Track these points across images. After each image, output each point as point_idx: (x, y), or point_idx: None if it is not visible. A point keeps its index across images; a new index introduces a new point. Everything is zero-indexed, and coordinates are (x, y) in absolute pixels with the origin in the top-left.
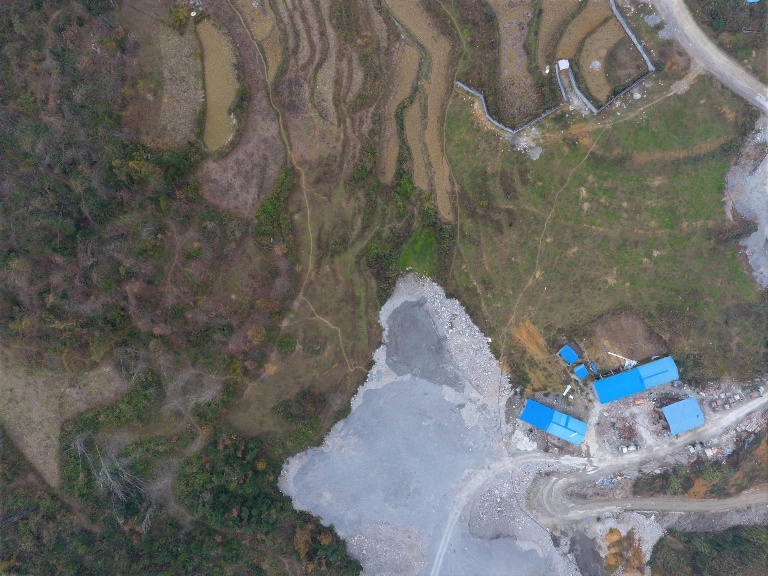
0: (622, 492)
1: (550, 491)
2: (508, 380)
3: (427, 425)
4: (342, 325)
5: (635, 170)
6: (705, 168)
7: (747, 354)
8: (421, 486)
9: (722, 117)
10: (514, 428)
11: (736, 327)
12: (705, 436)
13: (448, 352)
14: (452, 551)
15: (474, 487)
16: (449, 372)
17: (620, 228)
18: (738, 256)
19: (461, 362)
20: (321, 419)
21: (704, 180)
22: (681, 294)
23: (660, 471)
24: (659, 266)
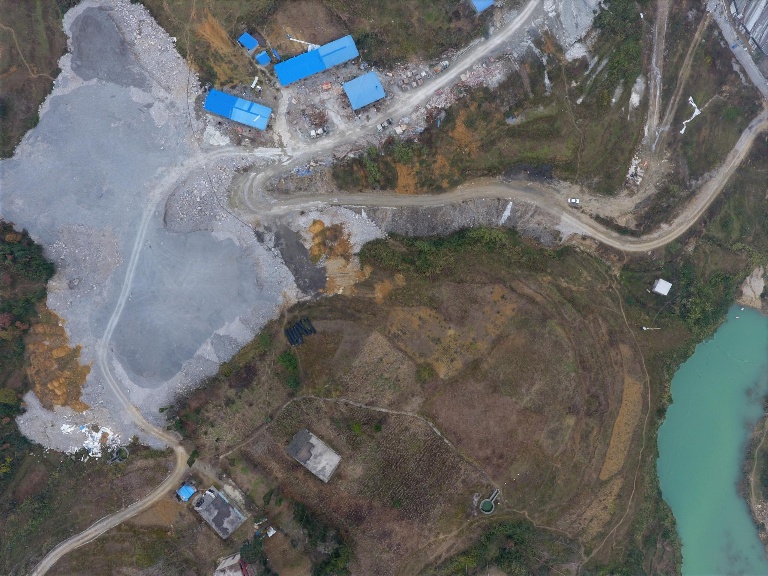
0: (324, 185)
1: (250, 188)
2: (197, 78)
3: (116, 126)
4: (15, 26)
5: None
6: None
7: (429, 29)
8: (114, 186)
9: None
10: (205, 124)
11: (413, 1)
12: (396, 116)
13: (134, 55)
14: (148, 247)
15: (168, 184)
16: (135, 73)
17: None
18: None
19: (149, 65)
20: (8, 128)
21: None
22: None
23: (354, 155)
24: None
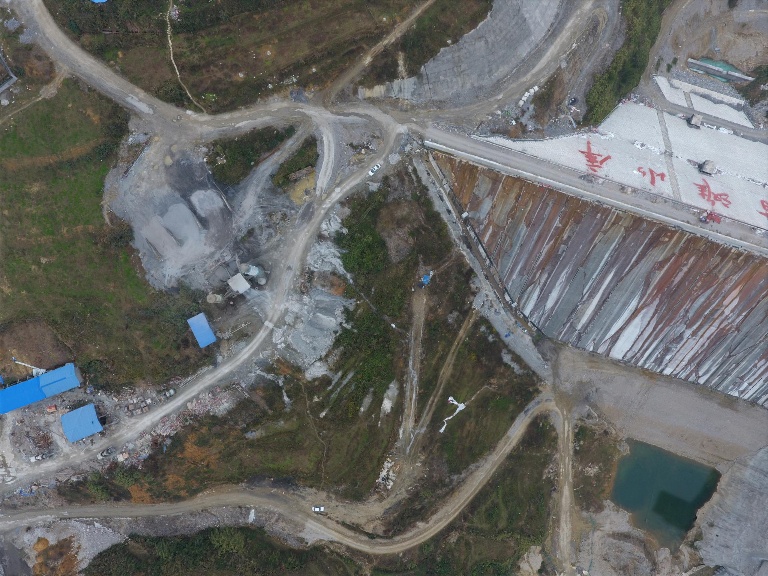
0: (52, 501)
1: None
2: None
3: None
4: None
5: (11, 177)
6: (84, 172)
7: (156, 357)
8: None
9: (89, 120)
10: None
11: (138, 331)
12: (121, 441)
13: None
14: None
15: None
16: None
17: (3, 236)
18: (131, 259)
19: None
20: None
21: (83, 184)
22: (79, 300)
23: (78, 478)
24: (50, 273)
